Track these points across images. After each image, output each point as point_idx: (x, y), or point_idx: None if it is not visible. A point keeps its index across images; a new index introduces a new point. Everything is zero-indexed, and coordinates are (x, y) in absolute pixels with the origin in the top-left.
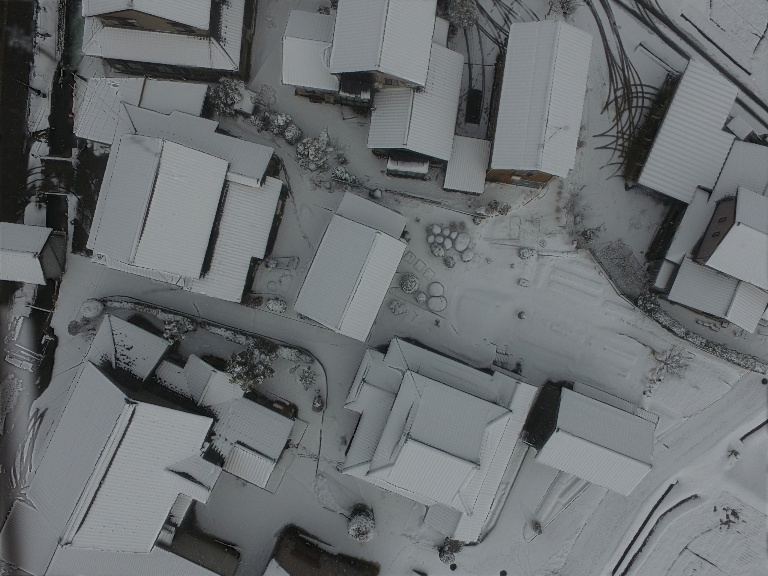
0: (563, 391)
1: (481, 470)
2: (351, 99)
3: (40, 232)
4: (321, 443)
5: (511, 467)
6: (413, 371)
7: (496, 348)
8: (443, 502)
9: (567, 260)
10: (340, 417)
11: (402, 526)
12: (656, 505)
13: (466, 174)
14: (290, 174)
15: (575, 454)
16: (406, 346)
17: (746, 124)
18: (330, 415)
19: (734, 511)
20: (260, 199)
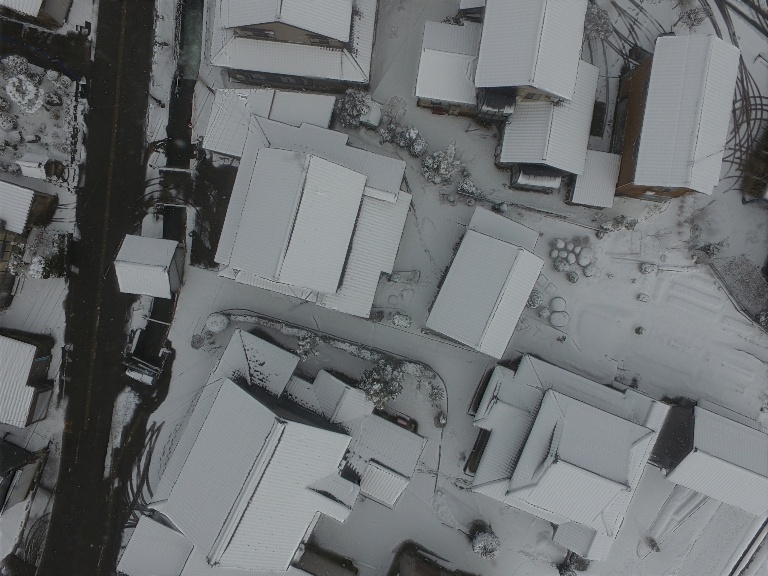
0: (696, 410)
1: None
2: (491, 113)
3: (167, 245)
4: (440, 459)
5: None
6: (554, 390)
7: (617, 364)
8: (583, 522)
9: (686, 275)
10: (460, 433)
11: (520, 542)
12: (765, 522)
13: (595, 188)
14: (412, 187)
15: (710, 474)
16: (538, 363)
17: None
18: (449, 430)
19: None
20: (391, 213)
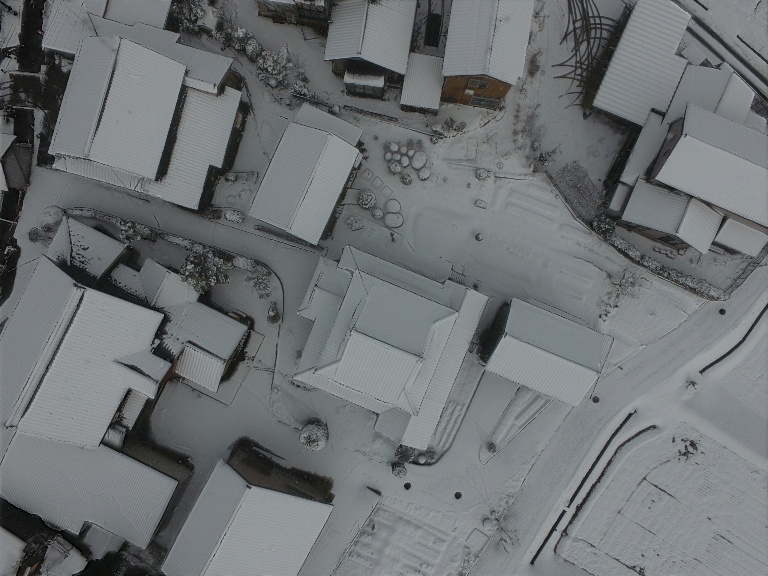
0: (513, 300)
1: (427, 369)
2: (307, 8)
3: (4, 138)
4: (277, 356)
5: (467, 388)
6: (362, 271)
7: (452, 265)
8: (389, 401)
9: (524, 183)
10: (296, 331)
11: (356, 442)
12: (614, 434)
13: (422, 90)
14: (252, 91)
15: (524, 361)
16: (359, 253)
17: (700, 52)
18: (286, 329)
19: (693, 442)
20: (218, 108)
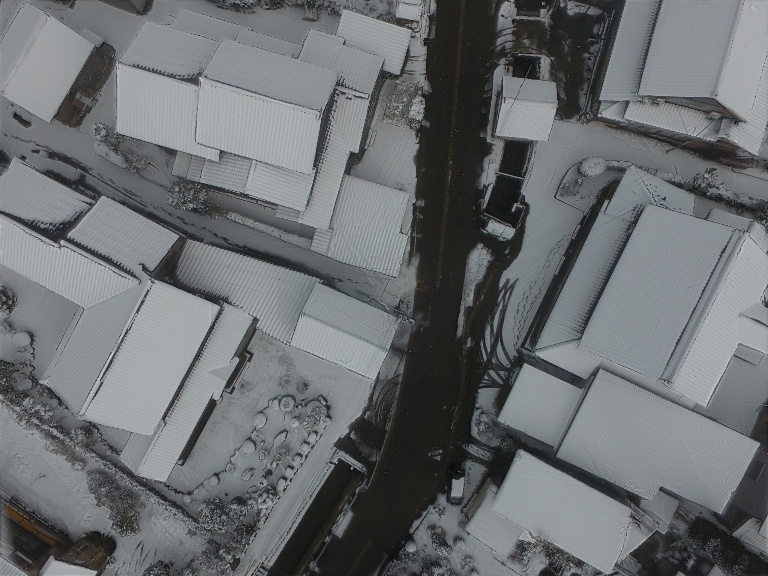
0: None
1: None
2: None
3: (547, 85)
4: None
5: None
6: None
7: None
8: None
9: None
10: None
11: None
12: None
13: None
14: None
15: None
16: None
17: None
18: None
19: None
20: None
